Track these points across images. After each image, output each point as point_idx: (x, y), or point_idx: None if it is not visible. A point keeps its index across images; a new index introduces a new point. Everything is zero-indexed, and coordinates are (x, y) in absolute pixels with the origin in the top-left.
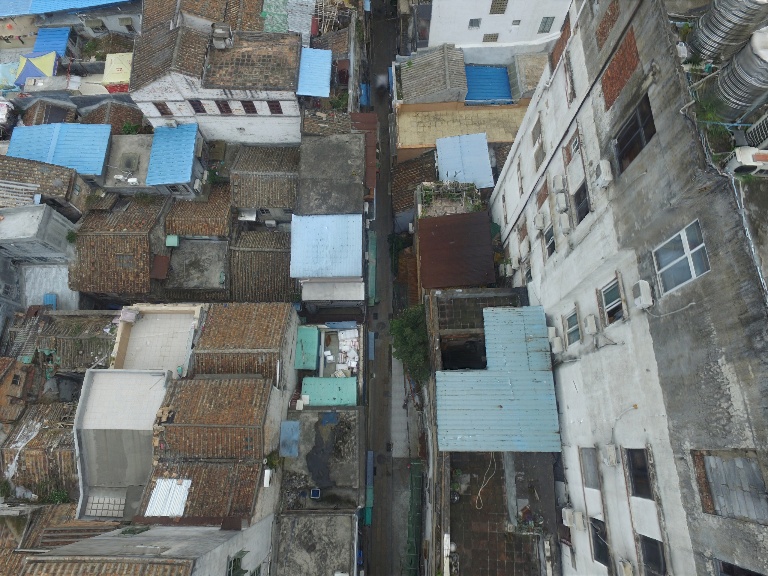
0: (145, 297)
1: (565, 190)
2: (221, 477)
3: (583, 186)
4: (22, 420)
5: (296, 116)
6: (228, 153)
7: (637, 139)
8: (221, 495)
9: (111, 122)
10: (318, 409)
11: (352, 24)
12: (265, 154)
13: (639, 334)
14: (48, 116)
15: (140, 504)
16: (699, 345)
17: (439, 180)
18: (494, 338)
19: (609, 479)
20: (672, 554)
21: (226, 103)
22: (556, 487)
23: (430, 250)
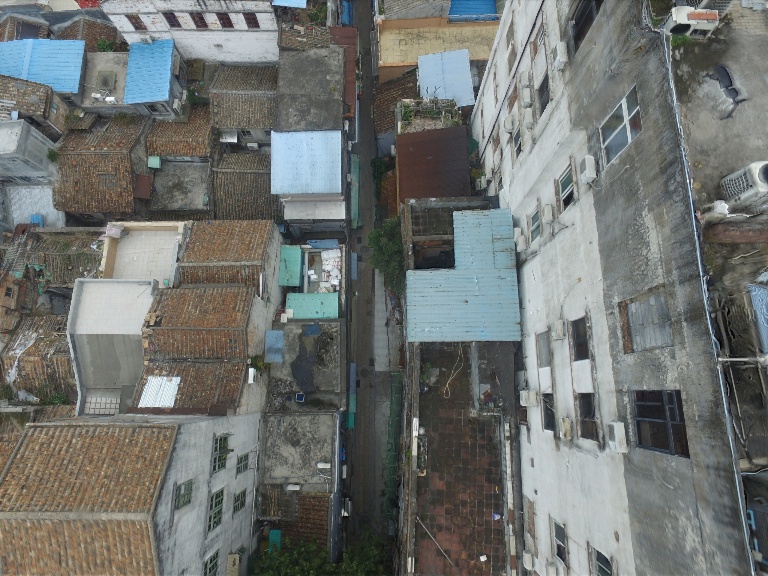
0: (130, 217)
1: (531, 85)
2: (208, 375)
3: (546, 78)
4: (18, 330)
5: (274, 31)
6: (207, 73)
7: (589, 14)
8: (208, 390)
9: (85, 40)
10: (301, 321)
11: None
12: (244, 73)
13: (585, 211)
14: (19, 33)
15: (133, 398)
16: (629, 204)
17: None
18: (463, 239)
19: (558, 353)
20: (600, 400)
21: (201, 16)
22: (517, 376)
23: (408, 165)
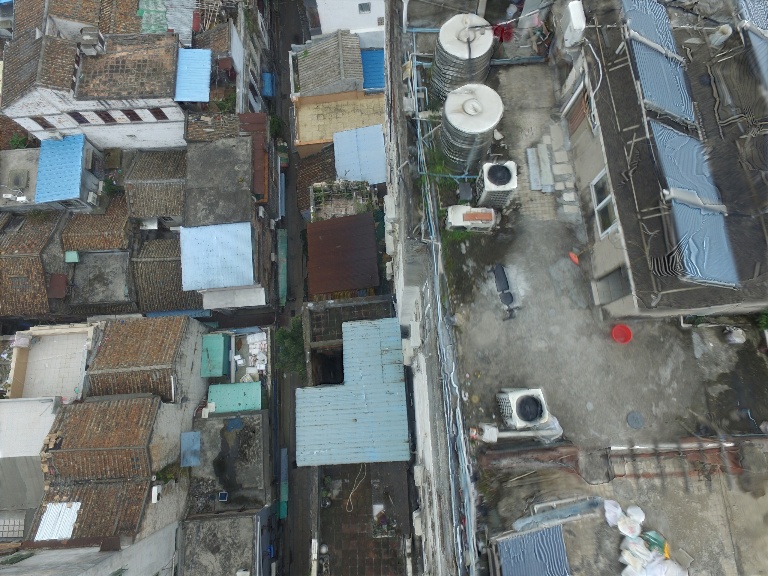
0: (47, 317)
1: None
2: (110, 497)
3: None
4: None
5: (183, 121)
6: (125, 160)
7: None
8: (108, 515)
9: None
10: (223, 416)
11: (238, 15)
12: (162, 159)
13: None
14: None
15: (30, 529)
16: None
17: (336, 177)
18: (351, 352)
19: None
20: None
21: (107, 113)
22: (416, 489)
23: (318, 255)
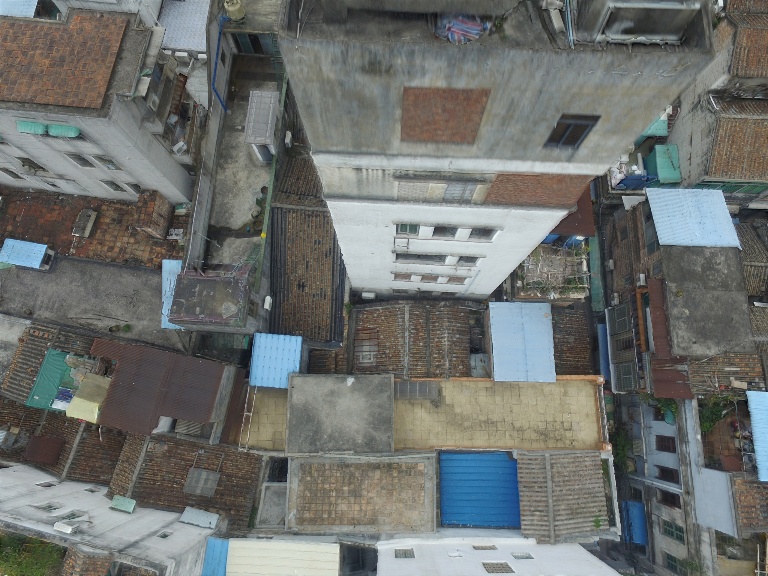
0: None
1: None
2: (760, 0)
3: None
4: None
5: None
6: None
7: None
8: None
9: None
10: None
11: None
12: None
13: None
14: None
15: None
16: None
17: None
18: None
19: None
20: None
21: None
22: None
23: (582, 199)
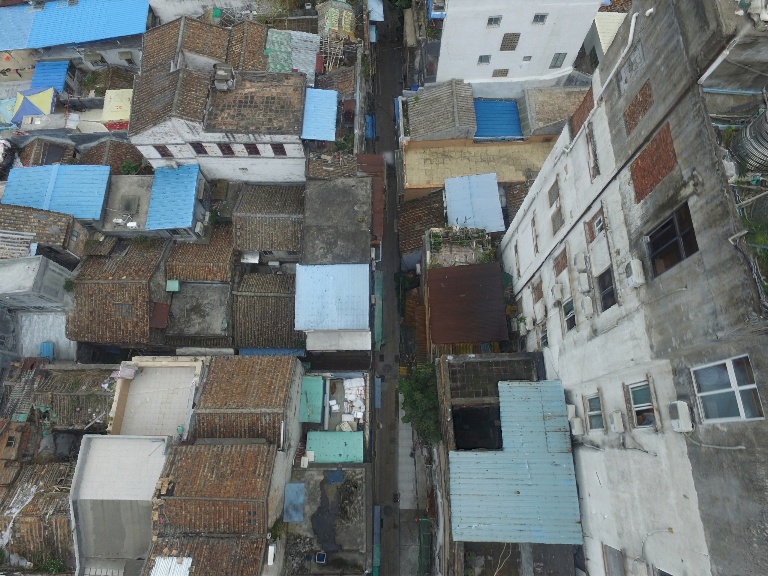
0: (145, 347)
1: (587, 270)
2: (223, 554)
3: (608, 271)
4: (17, 483)
5: (300, 158)
6: (230, 192)
7: (674, 247)
8: (223, 575)
9: (110, 161)
10: (323, 467)
11: (358, 60)
12: (268, 194)
13: (675, 453)
14: (46, 155)
15: None
16: (750, 497)
17: (448, 223)
18: (510, 415)
19: None
20: None
21: (228, 145)
22: (576, 575)
23: (440, 303)
